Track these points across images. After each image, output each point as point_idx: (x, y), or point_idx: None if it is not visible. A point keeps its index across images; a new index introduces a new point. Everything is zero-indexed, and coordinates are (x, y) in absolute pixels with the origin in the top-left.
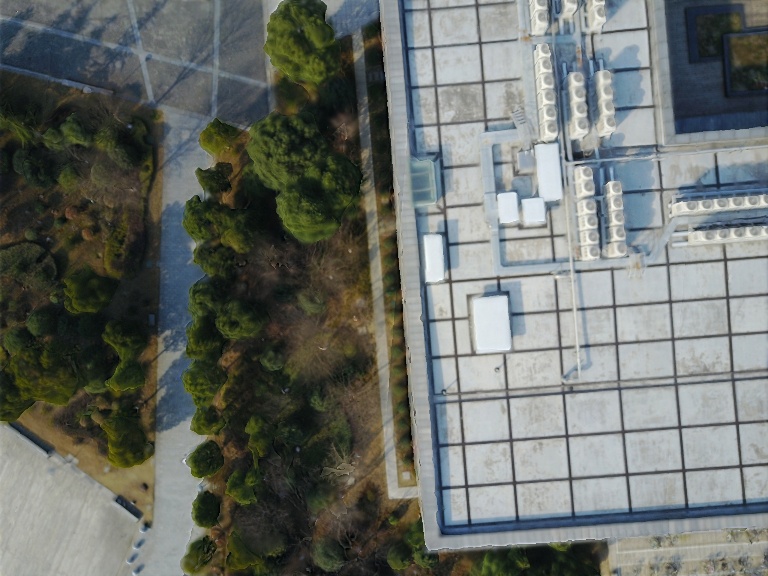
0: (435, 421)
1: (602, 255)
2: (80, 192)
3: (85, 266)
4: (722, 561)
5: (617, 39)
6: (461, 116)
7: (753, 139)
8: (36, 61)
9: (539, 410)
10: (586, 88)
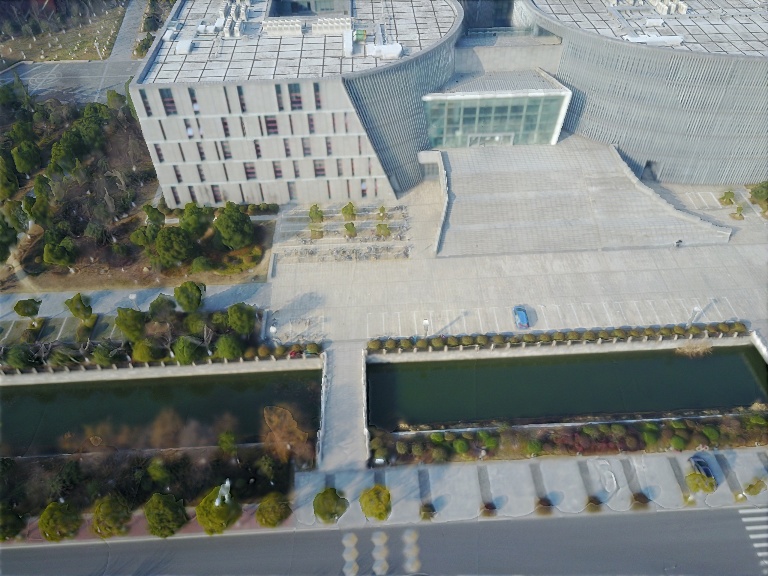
0: None
1: (233, 36)
2: (41, 125)
3: None
4: (343, 250)
5: (256, 7)
6: (195, 18)
7: None
8: (48, 98)
9: None
10: (237, 6)
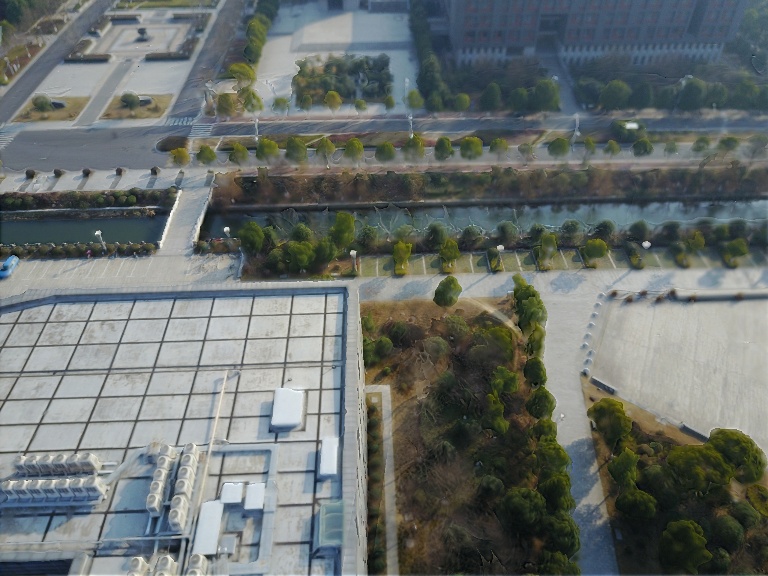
0: (343, 350)
1: None
2: None
3: (695, 571)
4: None
5: None
6: None
7: (0, 552)
8: None
9: (263, 355)
10: None
